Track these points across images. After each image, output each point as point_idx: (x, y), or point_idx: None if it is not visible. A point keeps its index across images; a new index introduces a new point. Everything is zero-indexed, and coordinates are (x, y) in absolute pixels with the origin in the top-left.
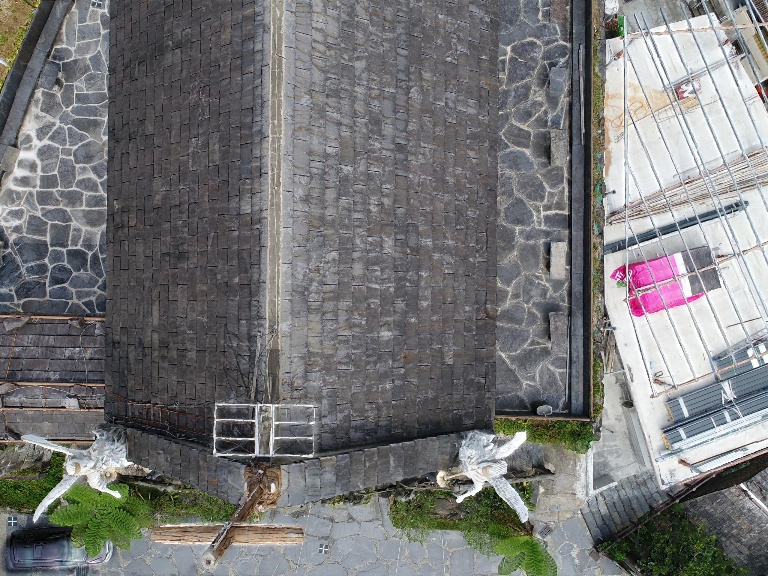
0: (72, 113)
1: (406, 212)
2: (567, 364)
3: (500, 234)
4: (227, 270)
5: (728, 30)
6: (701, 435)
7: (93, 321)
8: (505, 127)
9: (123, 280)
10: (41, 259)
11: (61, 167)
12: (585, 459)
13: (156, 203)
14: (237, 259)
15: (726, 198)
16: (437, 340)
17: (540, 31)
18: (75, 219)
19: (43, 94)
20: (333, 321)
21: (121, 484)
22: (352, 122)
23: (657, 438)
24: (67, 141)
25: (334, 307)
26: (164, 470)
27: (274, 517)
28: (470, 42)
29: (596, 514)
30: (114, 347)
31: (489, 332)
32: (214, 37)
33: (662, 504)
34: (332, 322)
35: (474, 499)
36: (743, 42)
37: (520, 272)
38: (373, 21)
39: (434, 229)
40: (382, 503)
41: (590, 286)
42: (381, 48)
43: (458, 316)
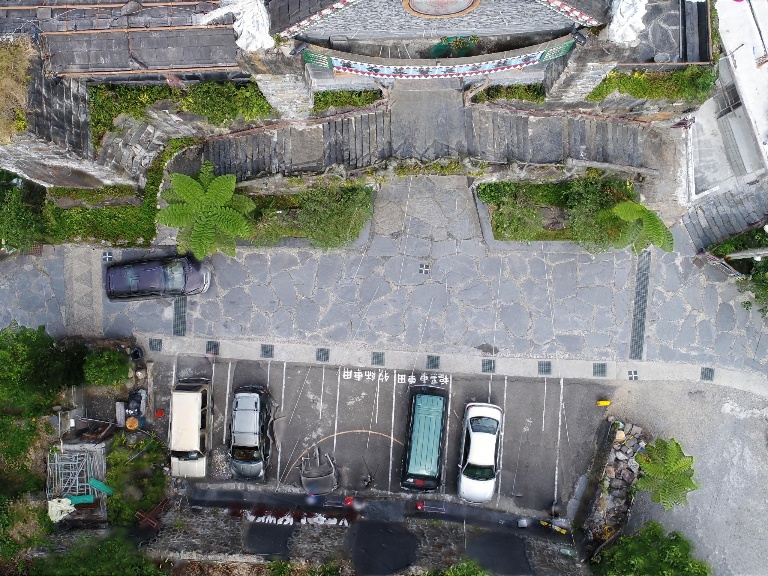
0: None
1: None
2: (680, 20)
3: None
4: None
5: None
6: None
7: None
8: None
9: None
10: None
11: None
12: (686, 164)
13: None
14: None
15: None
16: None
17: None
18: None
19: None
20: None
21: (228, 174)
22: None
23: (763, 123)
24: None
25: None
26: (321, 0)
27: (372, 239)
28: None
29: (697, 226)
30: None
31: None
32: None
33: (761, 219)
34: None
35: (582, 189)
36: None
37: None
38: None
39: None
40: (482, 217)
41: None
42: None
43: None
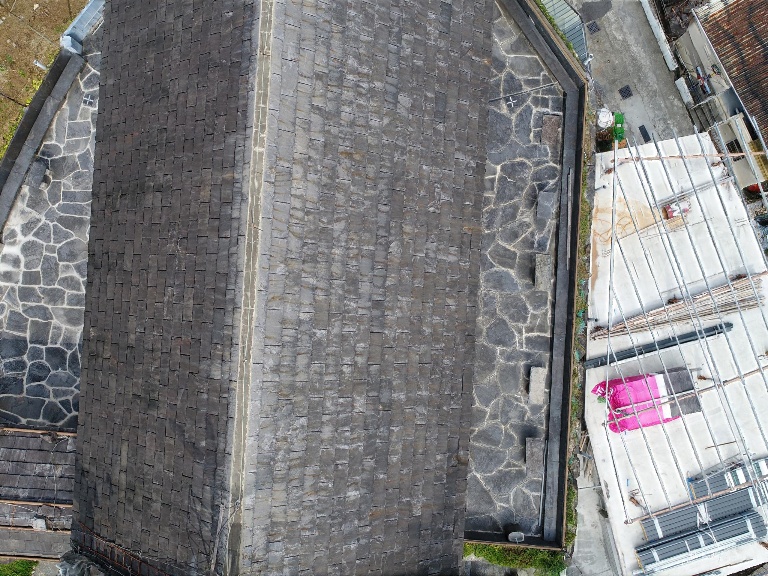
0: (58, 210)
1: (380, 368)
2: (542, 488)
3: (481, 354)
4: (195, 431)
5: (724, 130)
6: (674, 558)
7: (66, 436)
8: (491, 246)
9: (95, 410)
10: (20, 355)
11: (44, 264)
12: None
13: (130, 342)
14: (205, 422)
15: (711, 319)
16: (406, 493)
17: (531, 152)
18: (56, 317)
19: (30, 189)
20: (299, 488)
21: None
22: (328, 285)
23: (630, 556)
24: (52, 238)
25: (300, 473)
26: None
27: None
28: (454, 189)
29: None
30: (83, 475)
31: (460, 478)
32: (194, 191)
33: None
34: (297, 489)
35: None
36: (739, 145)
37: (499, 393)
38: (355, 180)
39: (408, 382)
40: None
41: (568, 414)
42: (362, 207)
43: (429, 466)
